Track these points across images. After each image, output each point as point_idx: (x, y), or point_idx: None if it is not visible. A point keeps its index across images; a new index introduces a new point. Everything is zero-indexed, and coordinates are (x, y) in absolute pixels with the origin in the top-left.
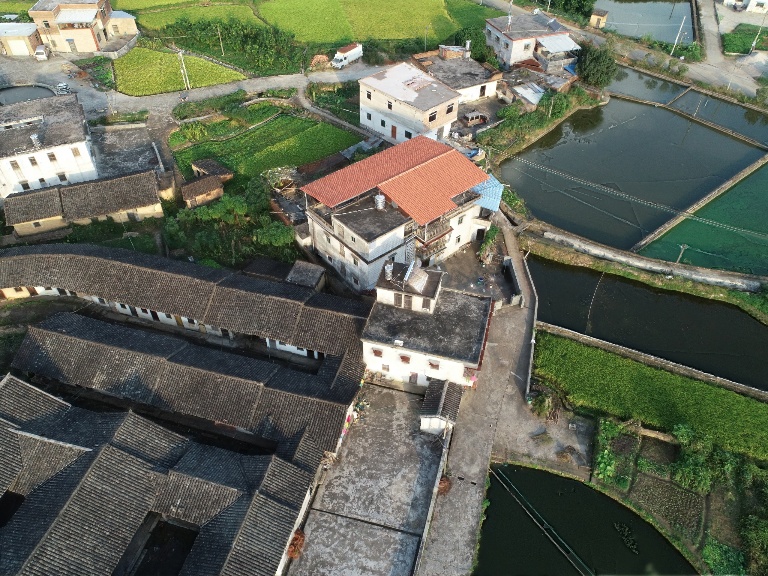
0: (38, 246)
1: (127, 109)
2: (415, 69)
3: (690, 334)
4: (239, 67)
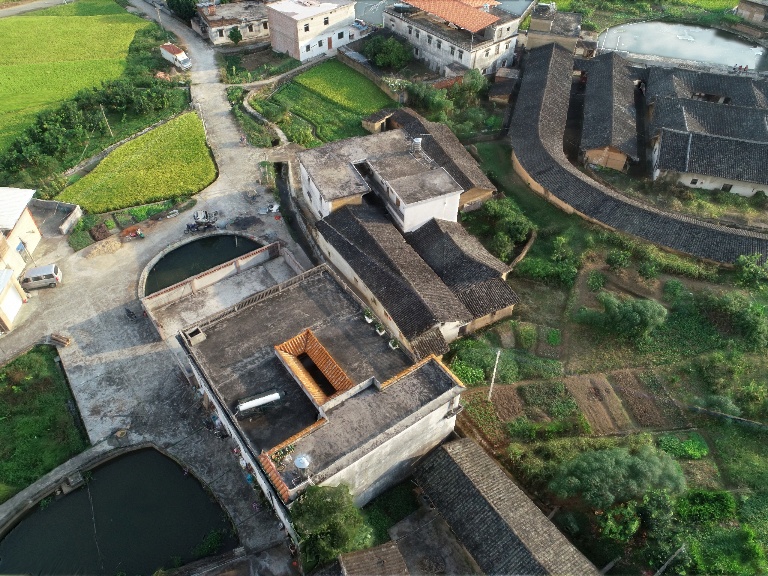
0: (525, 162)
1: (252, 177)
2: (280, 2)
3: (508, 1)
4: (155, 122)
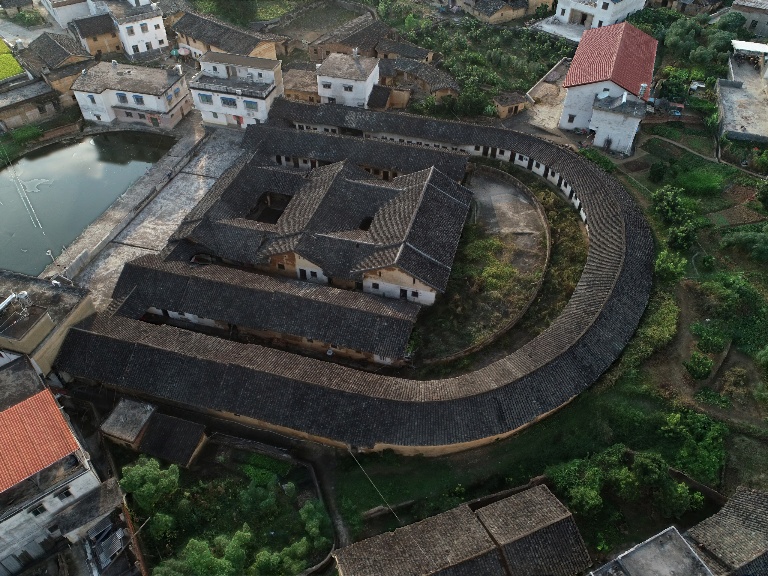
0: (469, 434)
1: None
2: None
3: None
4: None
